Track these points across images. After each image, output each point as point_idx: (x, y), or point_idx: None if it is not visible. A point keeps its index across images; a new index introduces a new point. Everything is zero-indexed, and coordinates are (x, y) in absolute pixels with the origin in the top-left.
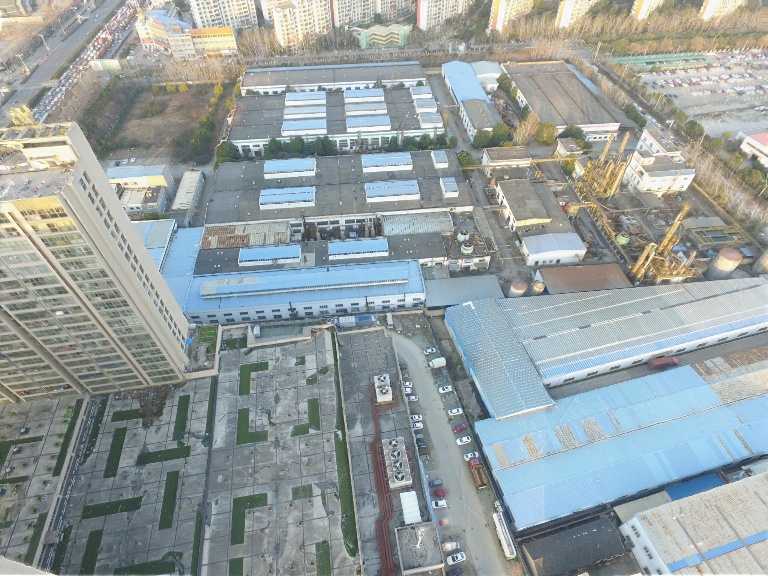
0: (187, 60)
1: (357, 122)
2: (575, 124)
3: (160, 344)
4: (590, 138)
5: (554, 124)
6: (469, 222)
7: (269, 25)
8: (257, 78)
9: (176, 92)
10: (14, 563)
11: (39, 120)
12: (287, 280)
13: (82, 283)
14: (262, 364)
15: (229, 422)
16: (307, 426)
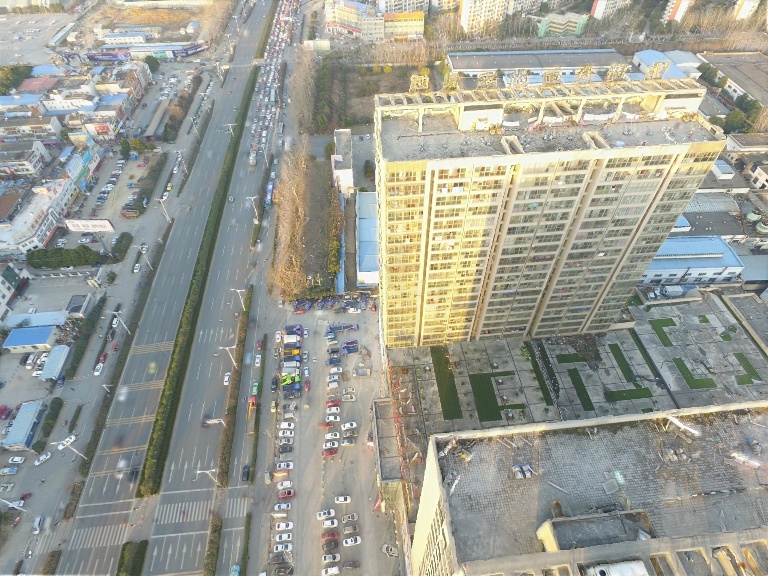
0: (374, 43)
1: None
2: None
3: None
4: None
5: None
6: (747, 203)
7: (437, 12)
8: (465, 61)
9: (380, 73)
10: None
11: (269, 96)
12: None
13: (648, 226)
14: (668, 320)
15: (671, 369)
16: (748, 377)
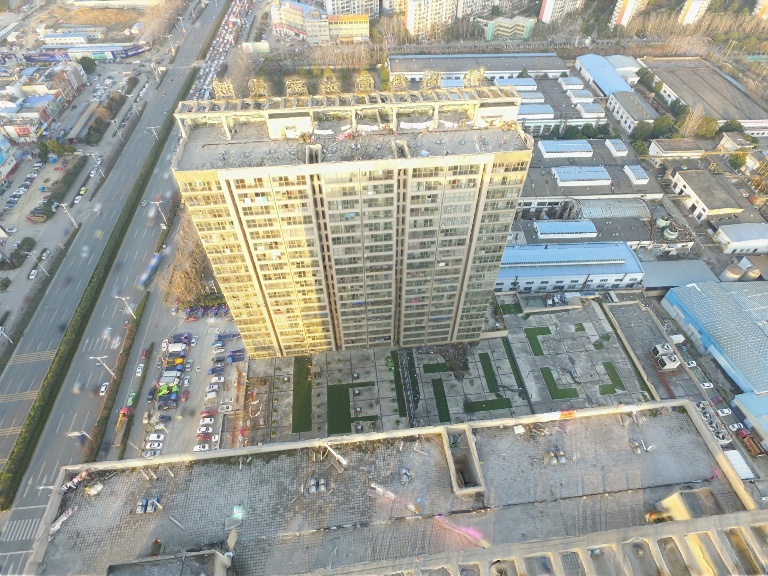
0: (320, 46)
1: (521, 109)
2: (736, 119)
3: None
4: (748, 134)
5: (716, 118)
6: (660, 209)
7: (388, 14)
8: (404, 64)
9: (321, 76)
10: None
11: (202, 98)
12: (510, 255)
13: (482, 236)
14: (544, 328)
15: (536, 379)
16: (612, 386)
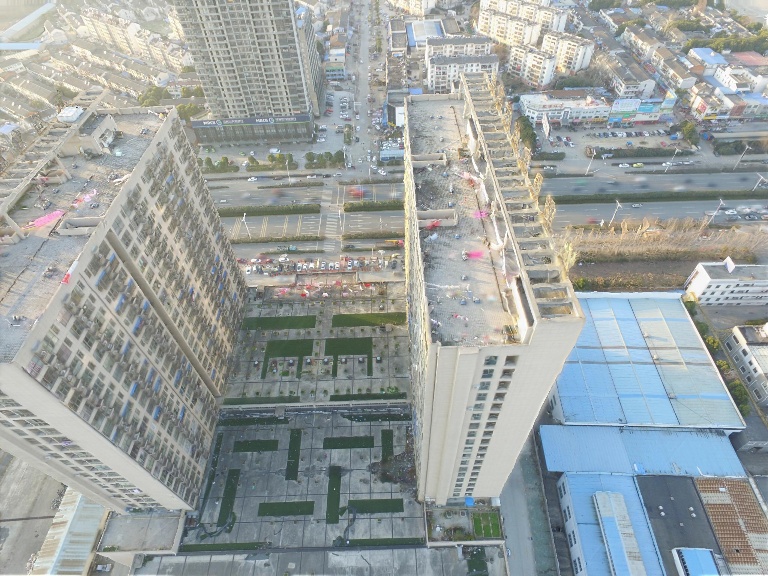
0: None
1: None
2: None
3: (426, 475)
4: None
5: None
6: None
7: None
8: None
9: None
10: (92, 430)
11: None
12: None
13: None
14: None
15: (358, 570)
16: None
